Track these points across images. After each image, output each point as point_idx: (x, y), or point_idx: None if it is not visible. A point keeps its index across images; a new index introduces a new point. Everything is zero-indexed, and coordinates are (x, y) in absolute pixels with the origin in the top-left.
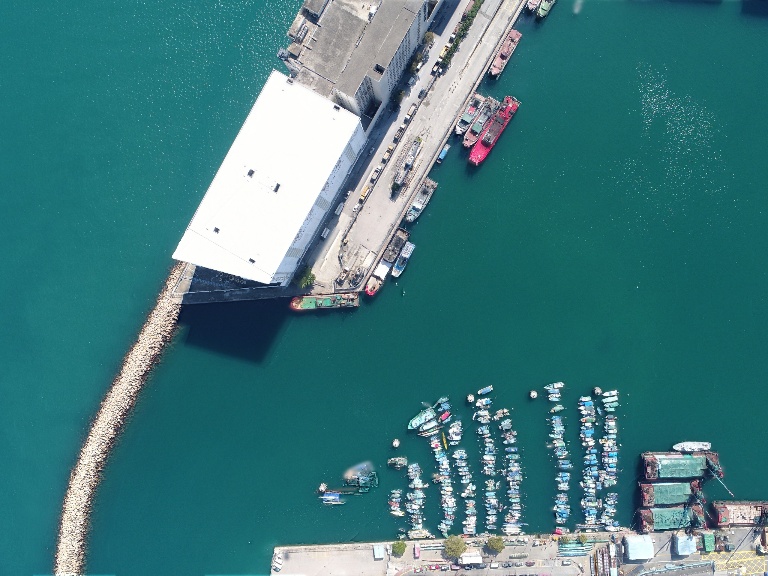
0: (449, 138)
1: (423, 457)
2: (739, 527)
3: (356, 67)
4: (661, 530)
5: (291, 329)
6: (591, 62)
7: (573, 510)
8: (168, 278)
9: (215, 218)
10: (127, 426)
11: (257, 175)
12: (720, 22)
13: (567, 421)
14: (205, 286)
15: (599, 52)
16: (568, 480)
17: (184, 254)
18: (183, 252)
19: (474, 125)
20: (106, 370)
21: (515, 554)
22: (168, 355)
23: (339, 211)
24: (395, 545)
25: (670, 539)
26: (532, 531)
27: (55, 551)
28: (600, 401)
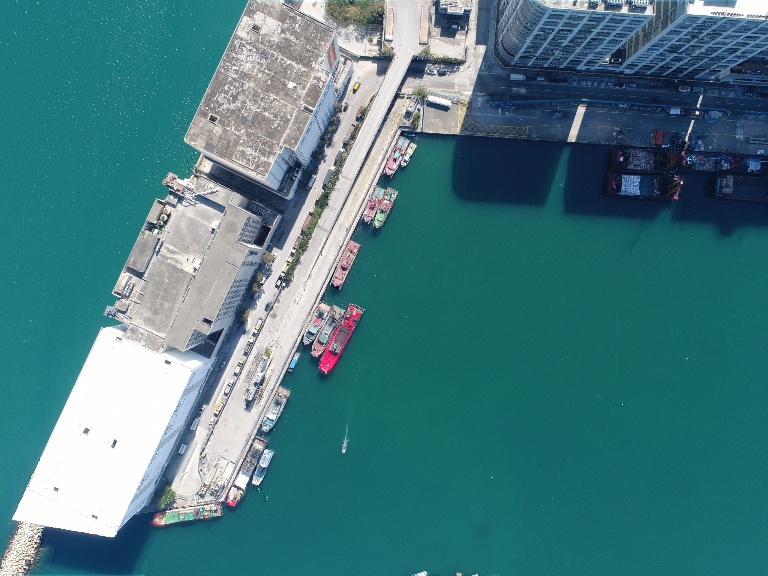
0: (298, 347)
1: None
2: None
3: (184, 321)
4: None
5: (157, 542)
6: (429, 266)
7: None
8: None
9: (54, 477)
10: None
11: (93, 432)
12: (546, 222)
13: None
14: None
15: (436, 256)
16: None
17: (25, 515)
18: (24, 513)
19: (320, 336)
20: None
21: None
22: None
23: (194, 427)
24: None
25: None
26: None
27: None
28: None
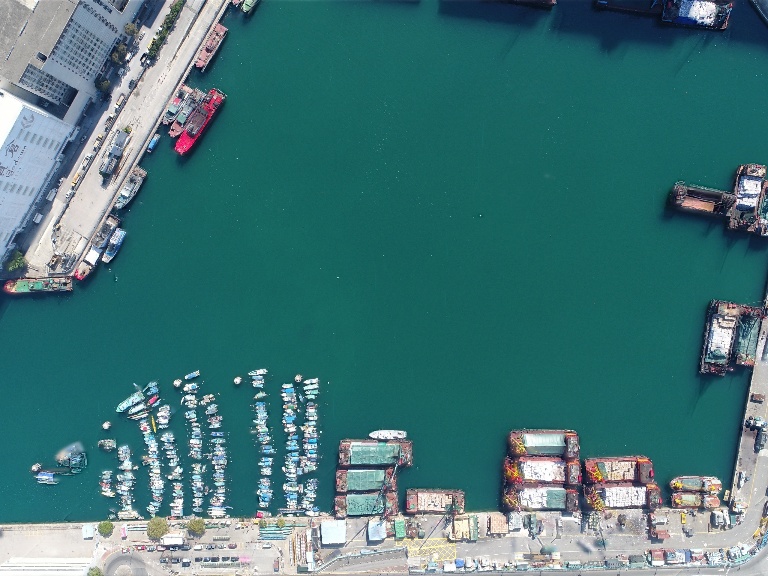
0: (159, 128)
1: (133, 440)
2: (432, 514)
3: (20, 55)
4: (358, 516)
5: (9, 311)
6: (295, 57)
7: (276, 495)
8: None
9: None
10: None
11: None
12: (418, 21)
13: (271, 407)
14: None
15: (303, 48)
16: (270, 465)
17: None
18: None
19: (178, 116)
20: None
21: (216, 536)
22: None
23: (50, 197)
24: (100, 525)
25: (366, 525)
26: (237, 514)
27: None
28: (302, 388)
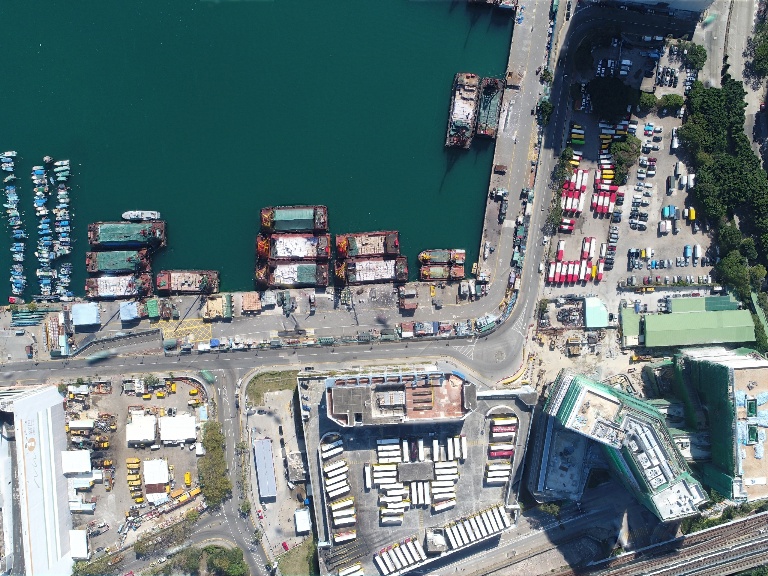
0: None
1: None
2: (187, 295)
3: None
4: (112, 299)
5: None
6: None
7: (29, 281)
8: None
9: None
10: None
11: None
12: None
13: (22, 191)
14: None
15: None
16: (22, 250)
17: None
18: None
19: None
20: None
21: None
22: None
23: None
24: None
25: None
26: None
27: None
28: (53, 171)
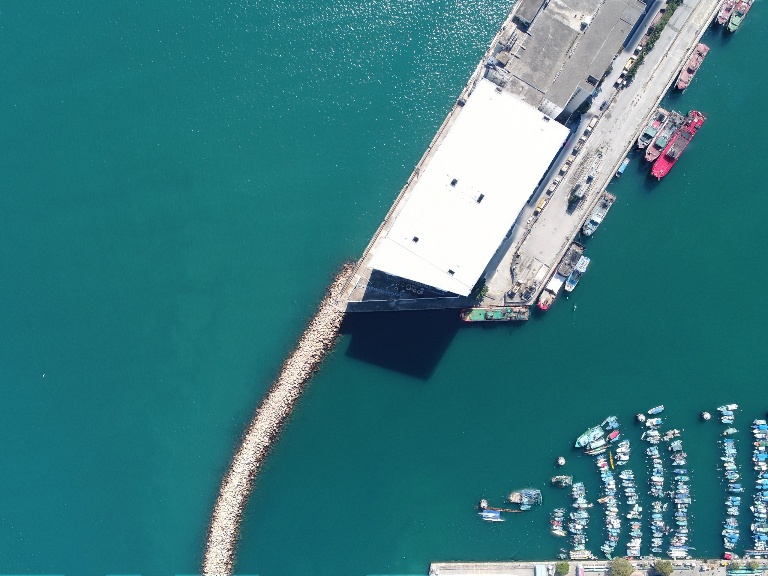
0: (629, 152)
1: (588, 476)
2: None
3: (568, 78)
4: None
5: (456, 341)
6: None
7: (742, 535)
8: (332, 285)
9: (414, 227)
10: (282, 434)
11: (460, 185)
12: None
13: (739, 444)
14: (379, 295)
15: None
16: (738, 504)
17: (381, 263)
18: (379, 261)
19: (658, 139)
20: (262, 376)
21: None
22: (327, 363)
23: None
24: (559, 565)
25: None
26: (698, 555)
27: (202, 560)
28: None
